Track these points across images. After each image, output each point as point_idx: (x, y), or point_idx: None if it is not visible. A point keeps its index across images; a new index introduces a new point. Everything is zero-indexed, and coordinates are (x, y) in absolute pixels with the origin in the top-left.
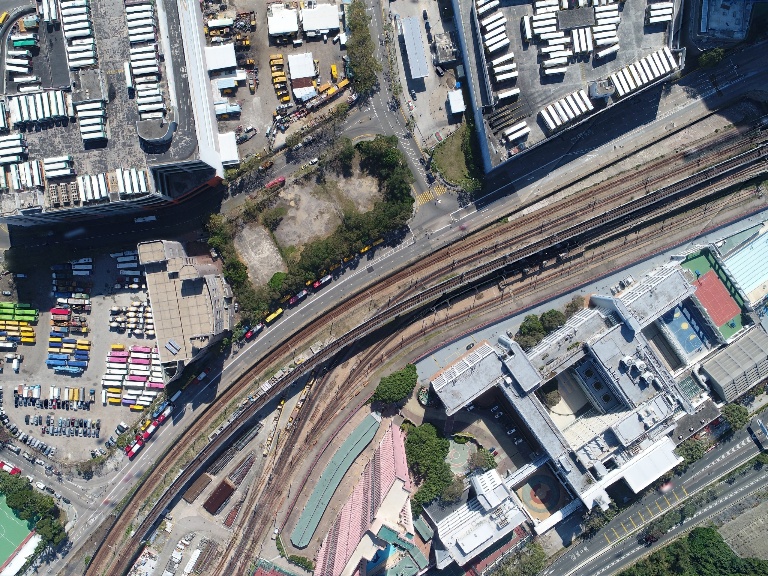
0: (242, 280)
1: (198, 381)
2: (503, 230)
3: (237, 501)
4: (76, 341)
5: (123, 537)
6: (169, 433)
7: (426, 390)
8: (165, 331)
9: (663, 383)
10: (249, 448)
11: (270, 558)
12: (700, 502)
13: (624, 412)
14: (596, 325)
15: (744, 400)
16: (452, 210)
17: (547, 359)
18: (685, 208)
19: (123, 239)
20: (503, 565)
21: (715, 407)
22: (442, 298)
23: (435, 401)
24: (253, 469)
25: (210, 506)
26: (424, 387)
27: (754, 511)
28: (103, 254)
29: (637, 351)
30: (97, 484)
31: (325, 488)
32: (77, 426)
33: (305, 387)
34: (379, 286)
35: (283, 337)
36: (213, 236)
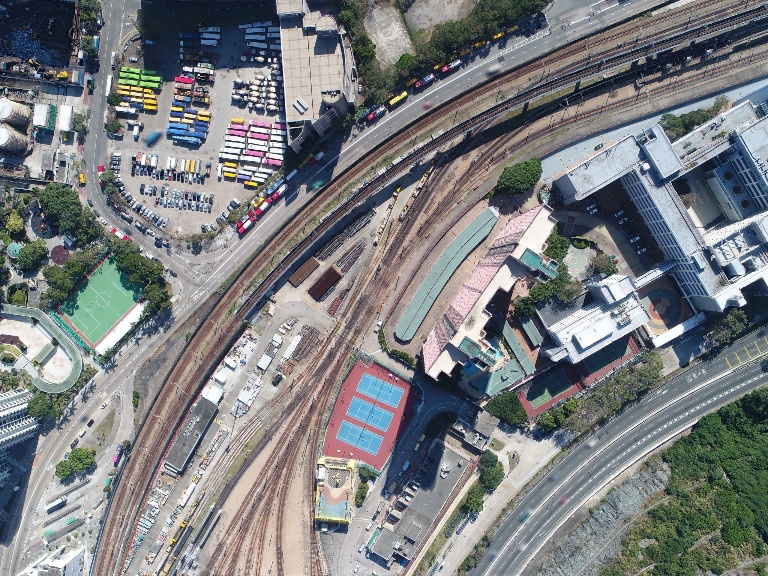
0: (371, 55)
1: (315, 161)
2: (646, 24)
3: (343, 289)
4: (197, 112)
5: (225, 316)
6: (281, 214)
7: (548, 189)
8: (294, 89)
9: None
10: (360, 236)
11: (371, 351)
12: None
13: (767, 211)
14: (745, 115)
15: None
16: (592, 2)
17: (689, 148)
18: None
19: (252, 12)
20: (614, 380)
21: None
22: (574, 93)
23: (557, 201)
24: (362, 258)
25: (315, 291)
26: (546, 186)
27: None
28: (231, 26)
29: None
30: (205, 260)
31: (435, 281)
32: (190, 199)
33: (423, 176)
34: (509, 76)
35: (404, 124)
36: (345, 10)
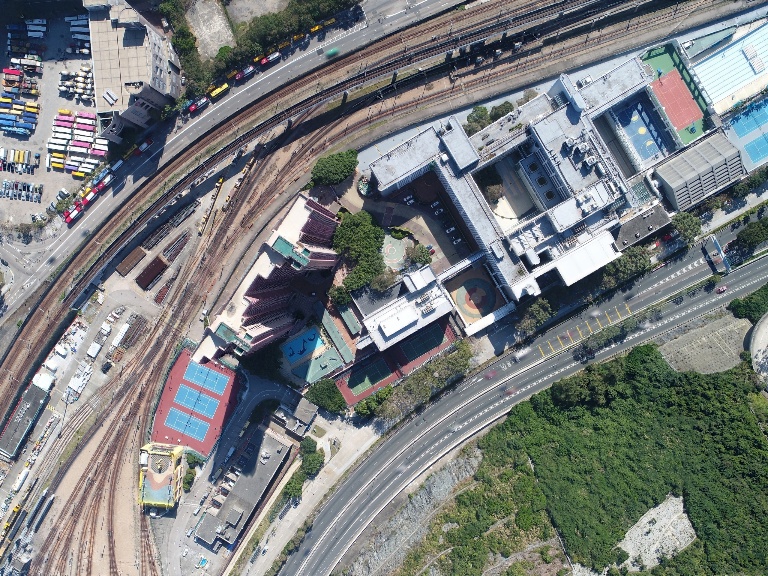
0: (189, 47)
1: (139, 151)
2: (459, 17)
3: (169, 278)
4: (26, 103)
5: (56, 305)
6: (108, 204)
7: (366, 180)
8: (104, 81)
9: (606, 168)
10: (185, 226)
11: (197, 339)
12: (643, 321)
13: None
14: (542, 107)
15: (701, 218)
16: None
17: (487, 140)
18: (654, 7)
19: (79, 5)
20: None
21: (665, 213)
22: None
23: (374, 192)
24: (187, 247)
25: (142, 280)
26: (365, 177)
27: (699, 331)
28: (58, 18)
29: (581, 134)
30: (35, 249)
31: None
32: (20, 189)
33: (245, 167)
34: (327, 69)
35: (227, 115)
36: (164, 2)
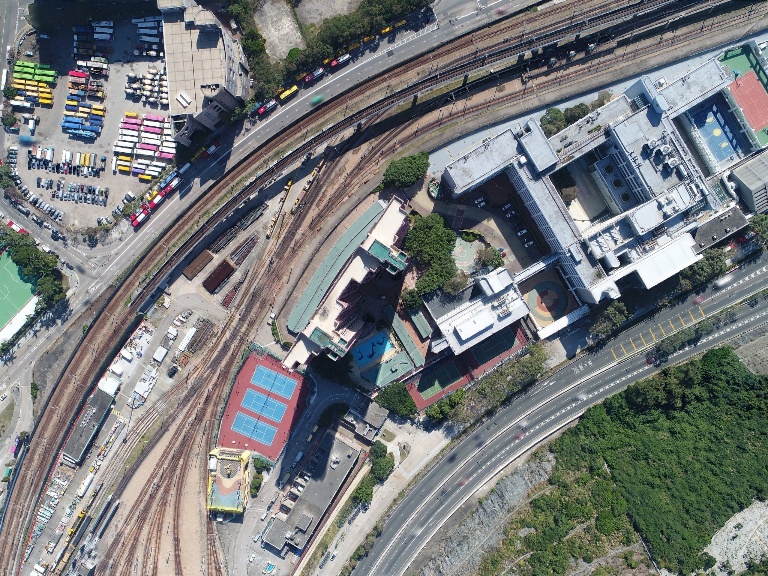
0: (259, 49)
1: (207, 154)
2: (531, 19)
3: (236, 282)
4: (92, 106)
5: (122, 309)
6: (175, 207)
7: (437, 183)
8: (177, 83)
9: (688, 170)
10: (253, 229)
11: (264, 343)
12: (717, 324)
13: None
14: (621, 109)
15: None
16: None
17: (565, 142)
18: (729, 8)
19: (146, 7)
20: None
21: (742, 215)
22: None
23: (445, 194)
24: (255, 251)
25: (209, 284)
26: (435, 179)
27: None
28: (125, 20)
29: (662, 136)
30: (101, 253)
31: (325, 274)
32: (86, 192)
33: (314, 169)
34: (398, 71)
35: (296, 118)
36: (234, 4)
